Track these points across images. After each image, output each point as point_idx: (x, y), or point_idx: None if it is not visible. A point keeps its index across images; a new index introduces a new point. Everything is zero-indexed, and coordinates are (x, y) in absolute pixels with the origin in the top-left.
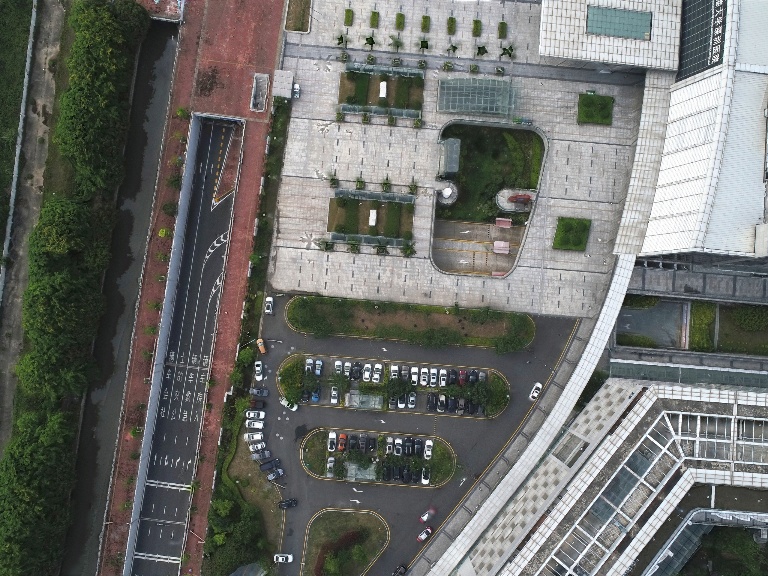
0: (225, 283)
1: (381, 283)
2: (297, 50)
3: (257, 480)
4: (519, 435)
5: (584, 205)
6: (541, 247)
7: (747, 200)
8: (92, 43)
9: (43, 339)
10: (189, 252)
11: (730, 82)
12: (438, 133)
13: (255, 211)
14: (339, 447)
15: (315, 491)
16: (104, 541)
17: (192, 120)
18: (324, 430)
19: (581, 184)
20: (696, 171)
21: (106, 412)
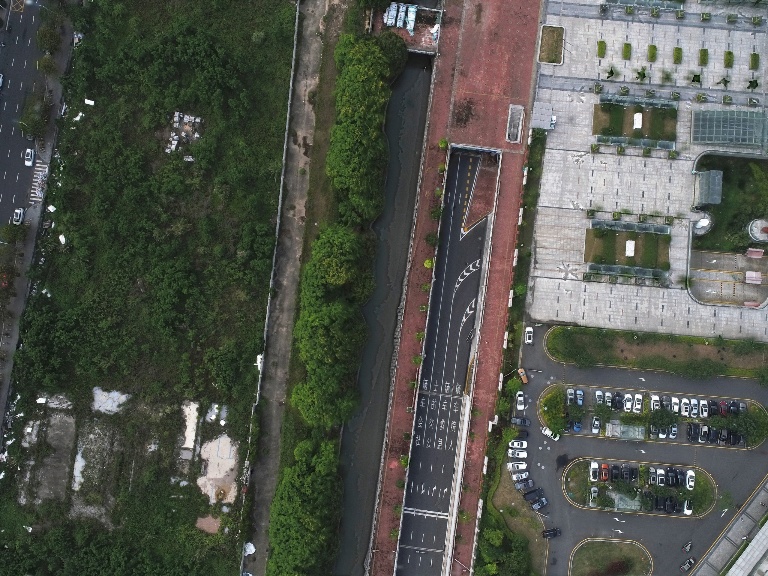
0: (485, 313)
1: (639, 313)
2: (550, 82)
3: (520, 509)
4: None
5: None
6: None
7: None
8: (367, 77)
9: (321, 369)
10: (439, 281)
11: None
12: (692, 164)
13: (513, 241)
14: (603, 477)
15: (578, 521)
16: (371, 569)
17: (449, 151)
18: (585, 460)
19: None
20: None
21: (363, 440)
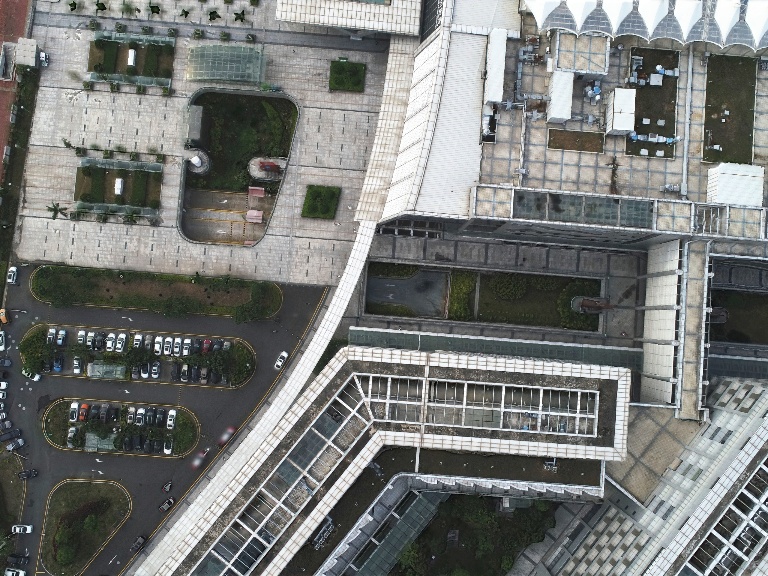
0: None
1: (127, 252)
2: (47, 18)
3: None
4: (264, 404)
5: (335, 173)
6: (290, 215)
7: (462, 162)
8: None
9: None
10: None
11: (445, 43)
12: (188, 101)
13: (1, 180)
14: (79, 417)
15: (57, 462)
16: None
17: None
18: (67, 400)
19: (332, 152)
20: (418, 134)
21: None
